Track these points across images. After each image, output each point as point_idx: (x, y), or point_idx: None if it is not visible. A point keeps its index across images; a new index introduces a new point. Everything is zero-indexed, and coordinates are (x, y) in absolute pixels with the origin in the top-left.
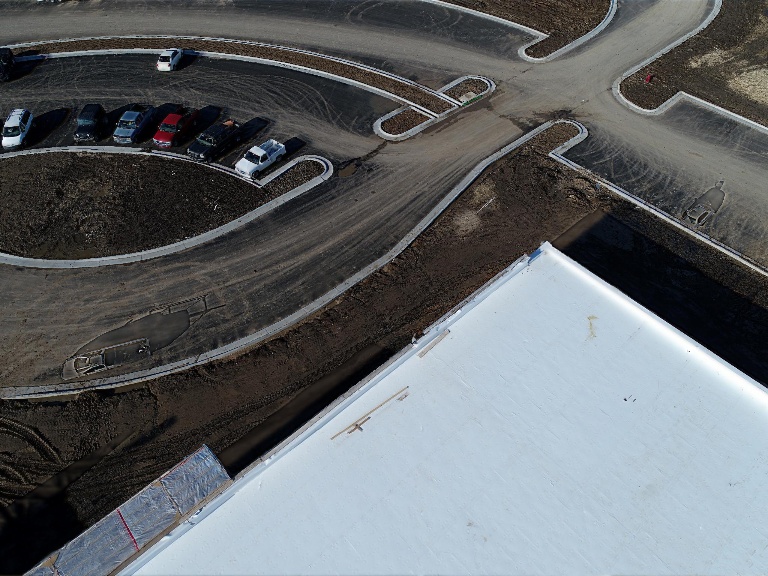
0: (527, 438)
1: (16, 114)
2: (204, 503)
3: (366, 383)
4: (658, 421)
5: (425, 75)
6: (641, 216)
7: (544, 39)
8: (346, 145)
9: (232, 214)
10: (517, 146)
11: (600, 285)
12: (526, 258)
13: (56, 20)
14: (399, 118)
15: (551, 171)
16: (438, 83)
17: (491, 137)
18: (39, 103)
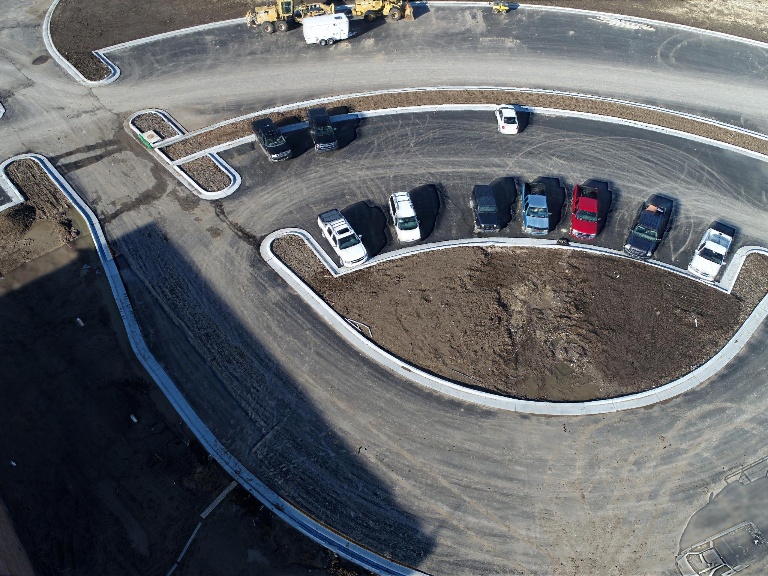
0: None
1: (403, 200)
2: None
3: None
4: None
5: None
6: None
7: None
8: None
9: (720, 331)
10: None
11: None
12: None
13: (340, 68)
14: None
15: None
16: None
17: None
18: (393, 178)
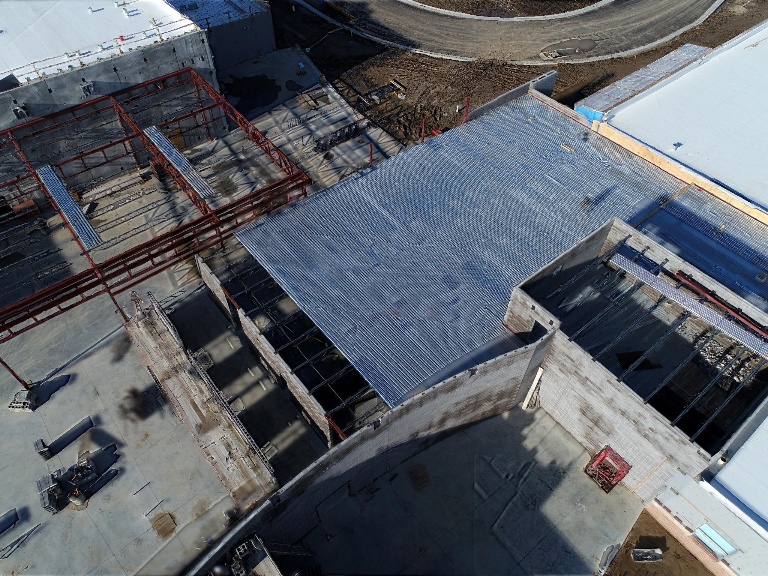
0: None
1: None
2: (705, 55)
3: (756, 28)
4: None
5: None
6: None
7: None
8: None
9: (587, 3)
10: None
11: None
12: None
13: None
14: None
15: None
16: None
17: None
18: None
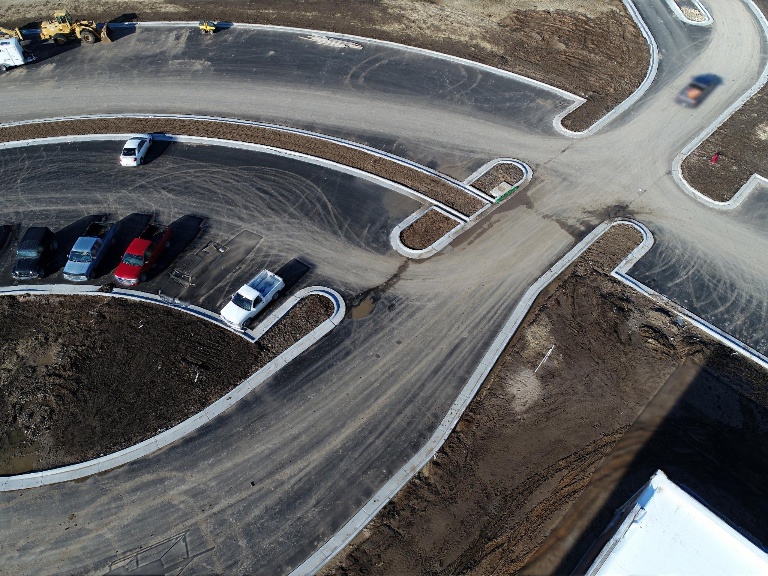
0: None
1: None
2: None
3: None
4: None
5: (446, 160)
6: (742, 367)
7: (581, 105)
8: (359, 268)
9: (219, 387)
10: (571, 262)
11: (748, 551)
12: (640, 513)
13: None
14: (421, 224)
15: (619, 300)
16: (463, 171)
17: (536, 249)
18: None
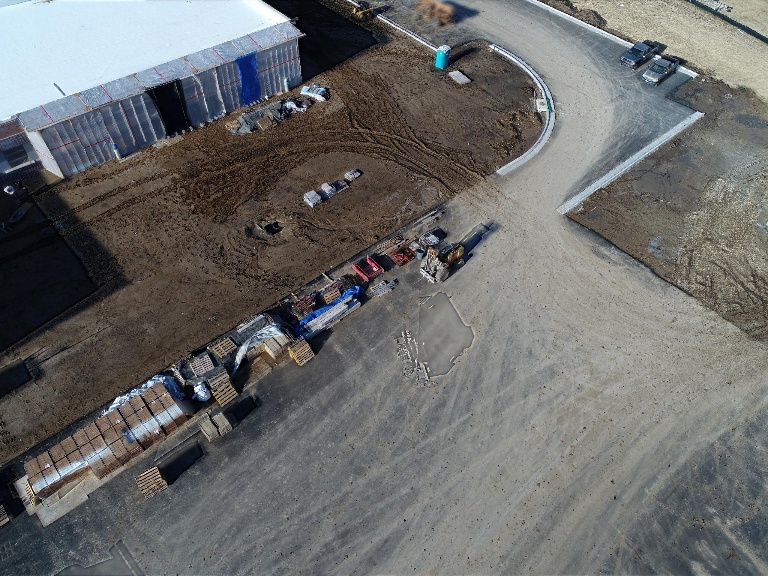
0: (128, 8)
1: None
2: None
3: None
4: (197, 7)
5: None
6: None
7: None
8: None
9: None
10: None
11: None
12: None
13: None
14: None
15: None
16: None
17: None
18: None
